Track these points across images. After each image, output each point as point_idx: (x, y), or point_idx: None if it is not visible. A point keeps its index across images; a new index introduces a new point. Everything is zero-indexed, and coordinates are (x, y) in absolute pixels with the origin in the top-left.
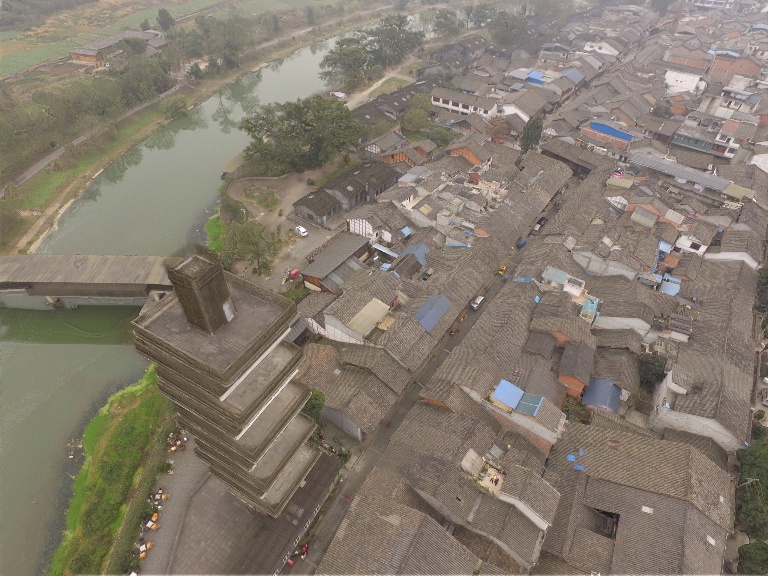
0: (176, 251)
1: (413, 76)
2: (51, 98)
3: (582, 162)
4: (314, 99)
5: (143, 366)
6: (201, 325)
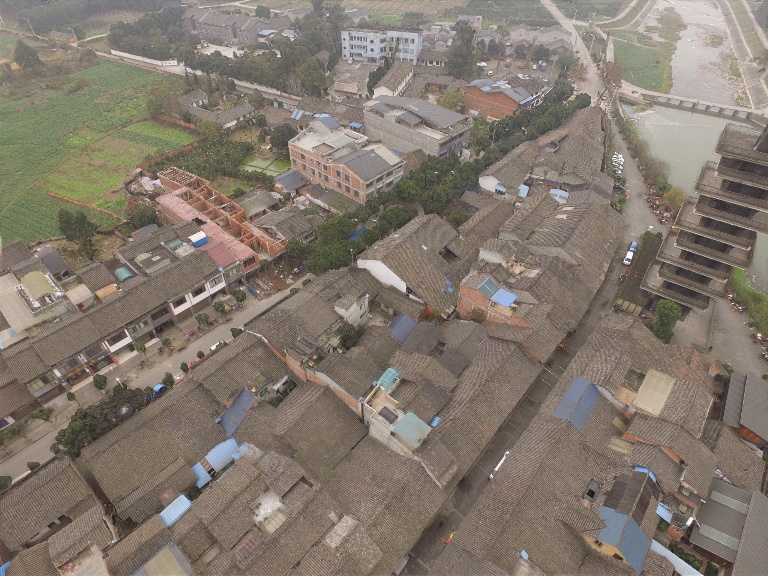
0: None
1: None
2: None
3: None
4: None
5: None
6: None
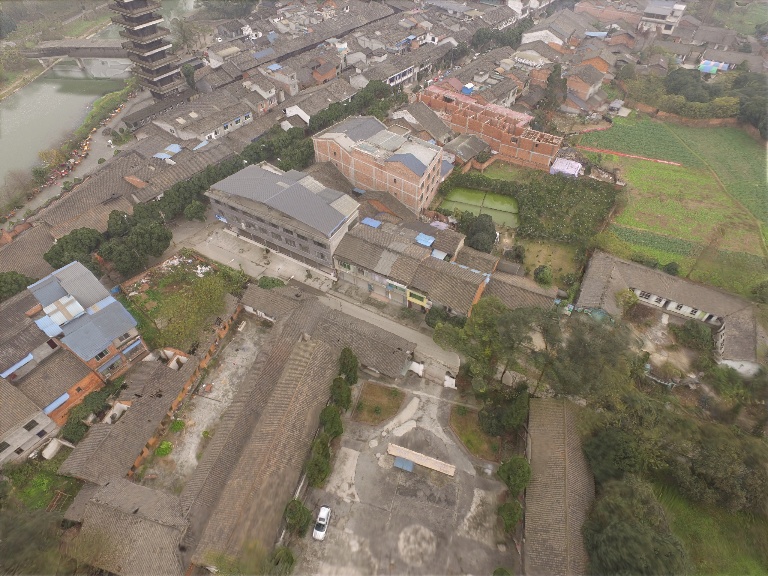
0: None
1: None
2: None
3: (404, 8)
4: None
5: None
6: None
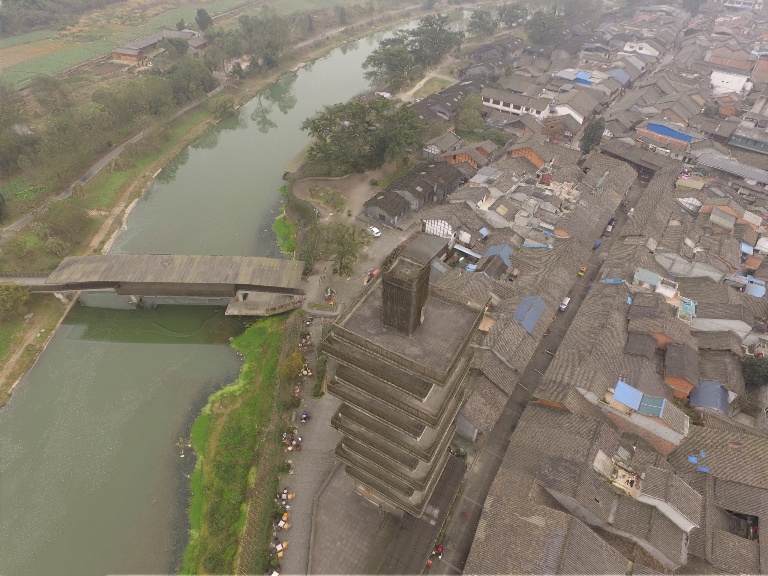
0: (249, 251)
1: (454, 76)
2: (110, 98)
3: (645, 163)
4: (378, 99)
5: (237, 366)
6: (401, 327)
